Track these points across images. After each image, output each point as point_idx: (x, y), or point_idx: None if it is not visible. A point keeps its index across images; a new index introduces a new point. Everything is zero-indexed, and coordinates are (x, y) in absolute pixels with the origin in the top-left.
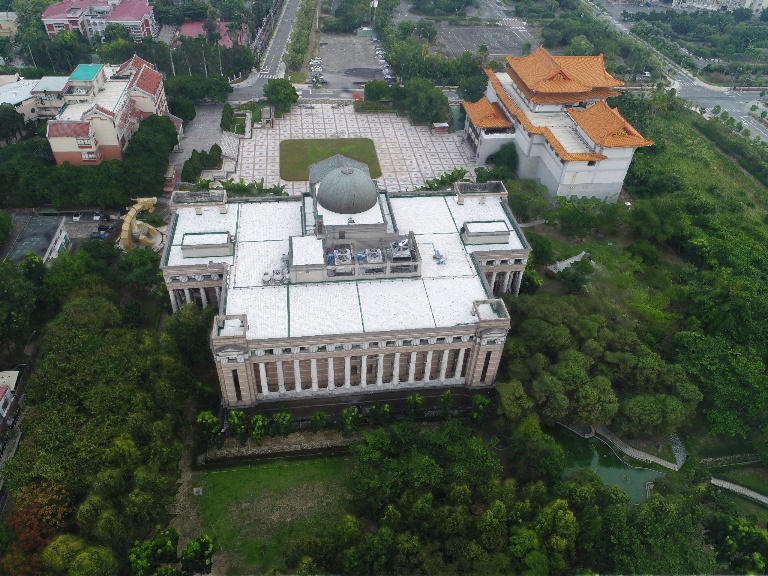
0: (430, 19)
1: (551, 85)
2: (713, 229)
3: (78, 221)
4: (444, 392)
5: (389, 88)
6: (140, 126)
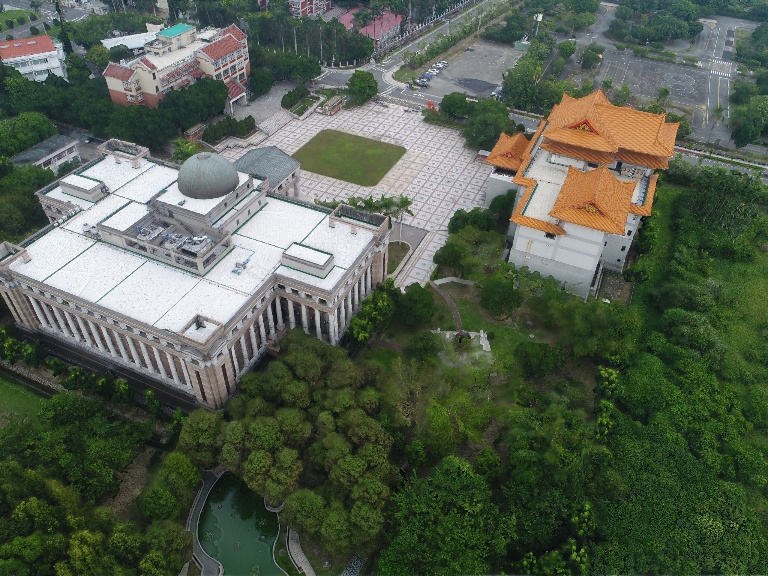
0: None
1: (570, 135)
2: (680, 370)
3: None
4: (182, 396)
5: (464, 104)
6: None
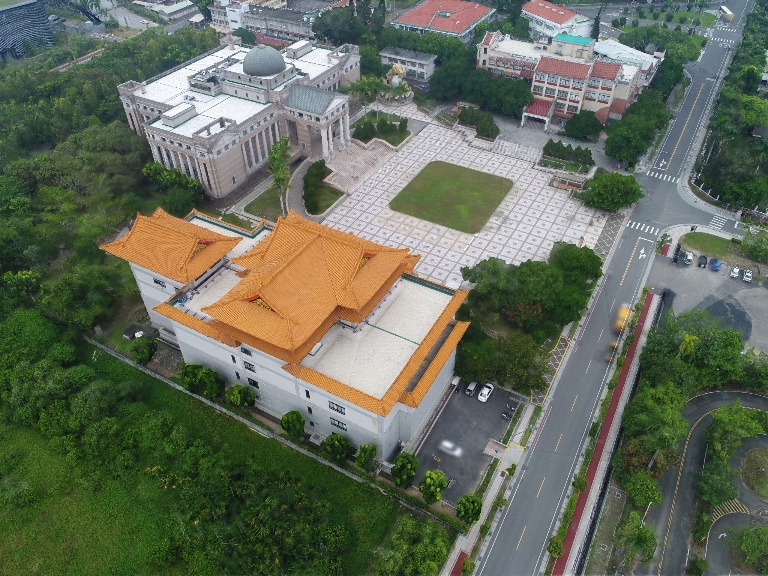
0: None
1: None
2: None
3: None
4: None
5: (566, 264)
6: None
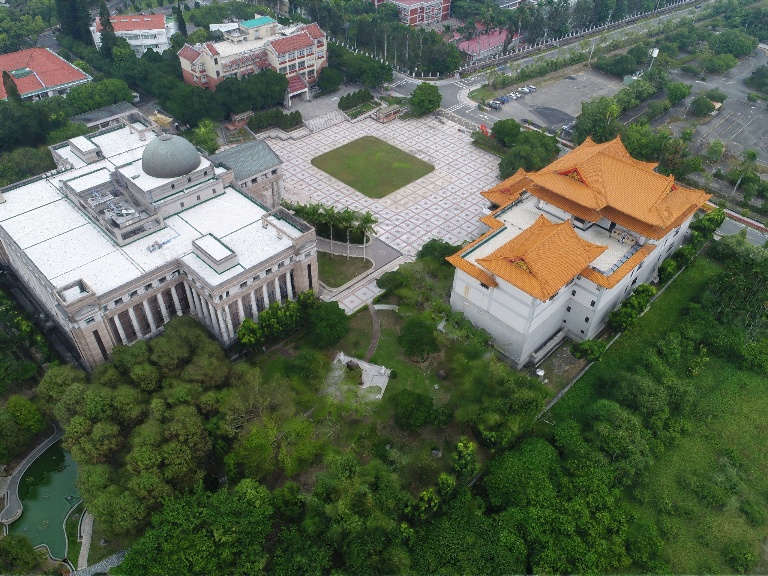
0: None
1: (558, 181)
2: (570, 471)
3: None
4: None
5: (514, 132)
6: (257, 74)
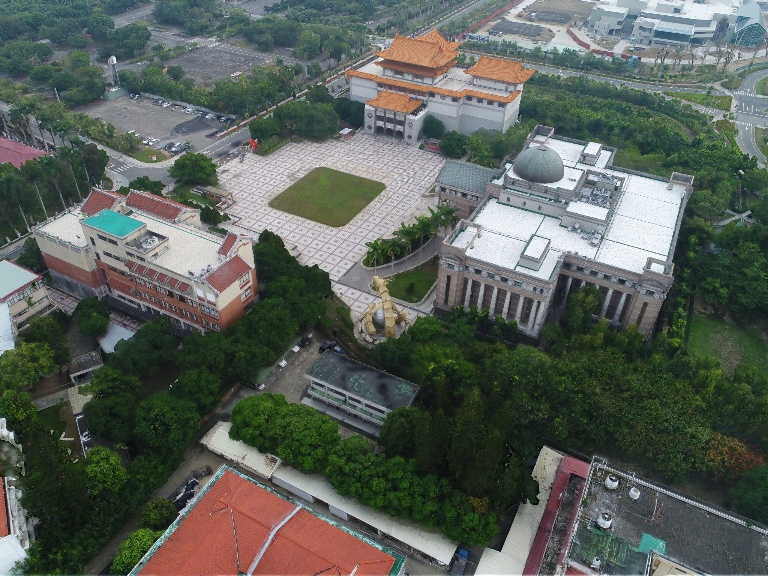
0: (134, 62)
1: (440, 59)
2: None
3: (287, 364)
4: None
5: (273, 122)
6: None
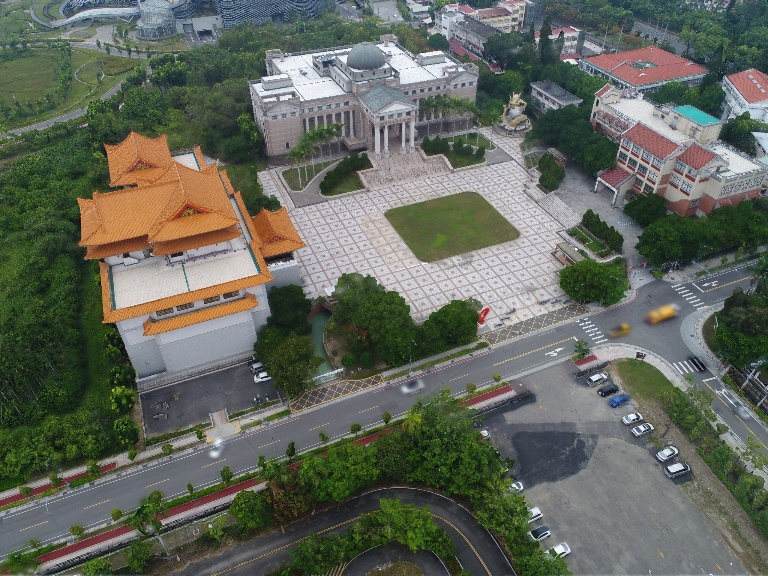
0: None
1: None
2: None
3: None
4: None
5: (436, 314)
6: None
